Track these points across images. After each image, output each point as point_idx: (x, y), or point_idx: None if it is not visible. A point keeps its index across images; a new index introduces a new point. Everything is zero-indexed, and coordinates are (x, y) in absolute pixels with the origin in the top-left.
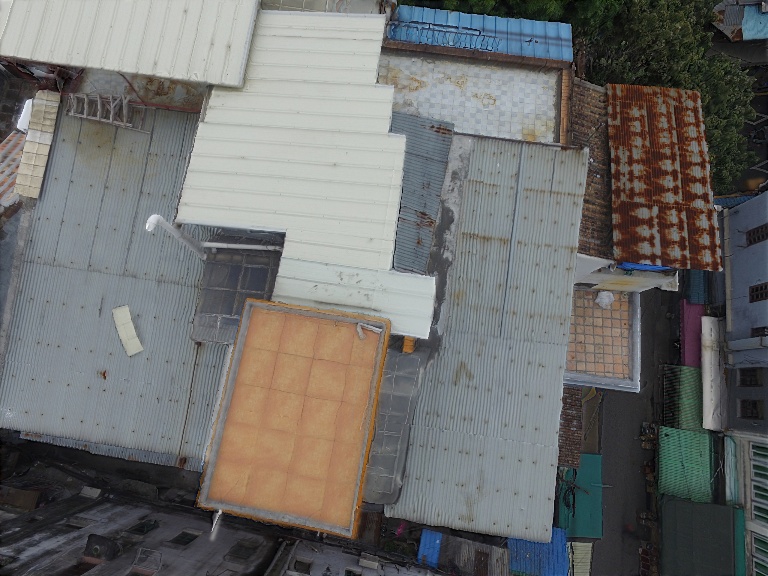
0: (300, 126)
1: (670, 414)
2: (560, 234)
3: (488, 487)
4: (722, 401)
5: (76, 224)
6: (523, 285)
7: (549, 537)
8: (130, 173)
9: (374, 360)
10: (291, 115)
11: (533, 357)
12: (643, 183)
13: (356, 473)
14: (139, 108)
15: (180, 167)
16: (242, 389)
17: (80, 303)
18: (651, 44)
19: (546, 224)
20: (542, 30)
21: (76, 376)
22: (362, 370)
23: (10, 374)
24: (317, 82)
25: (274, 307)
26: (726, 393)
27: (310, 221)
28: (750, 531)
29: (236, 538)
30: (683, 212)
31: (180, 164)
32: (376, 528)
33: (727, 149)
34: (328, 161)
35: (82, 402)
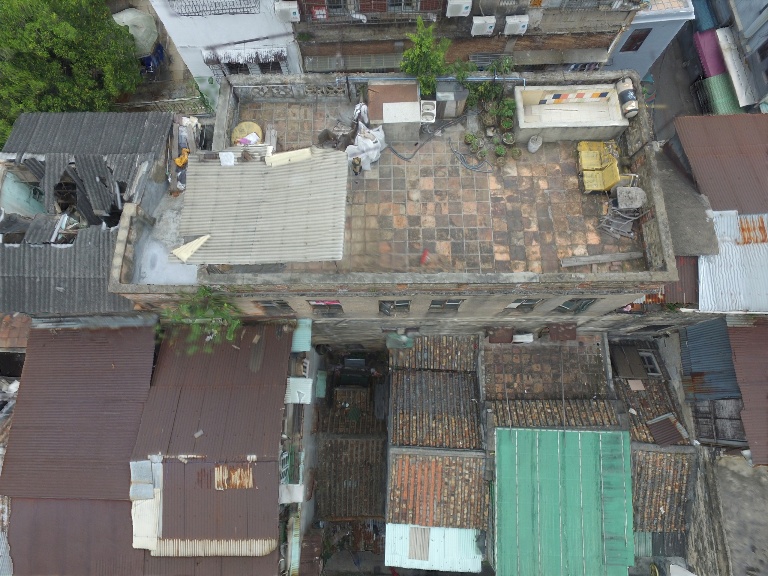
0: None
1: None
2: None
3: None
4: (750, 83)
5: None
6: None
7: None
8: None
9: None
10: None
11: None
12: None
13: None
14: None
15: None
16: None
17: None
18: None
19: None
20: None
21: None
22: None
23: None
24: None
25: None
26: (751, 75)
27: None
28: None
29: None
30: None
31: None
32: None
33: None
34: None
35: None
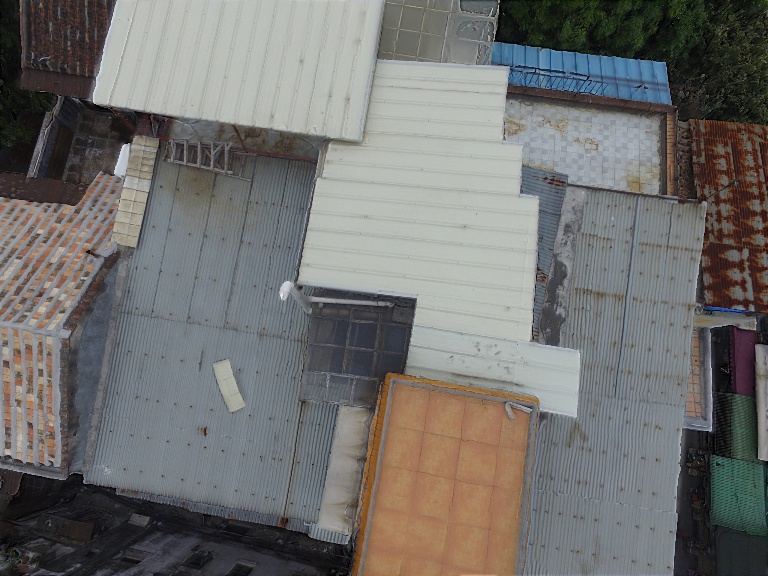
0: (425, 184)
1: (721, 443)
2: (677, 291)
3: (604, 554)
4: None
5: (174, 274)
6: (639, 343)
7: None
8: (230, 222)
9: (526, 442)
10: (414, 172)
11: (649, 418)
12: (731, 224)
13: (516, 566)
14: (239, 155)
15: (281, 216)
16: (389, 472)
17: (179, 356)
18: (732, 77)
19: (662, 280)
20: (636, 69)
21: (176, 432)
22: (513, 452)
23: (107, 429)
24: (440, 137)
25: (419, 384)
26: None
27: (442, 287)
28: None
29: (290, 570)
30: None
31: (281, 213)
32: None
33: None
34: (457, 222)
35: (182, 459)
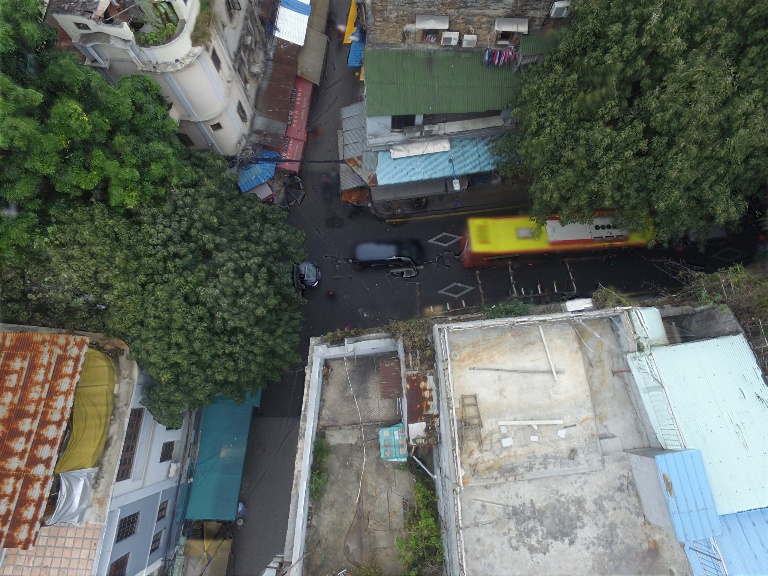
0: None
1: None
2: None
3: None
4: None
5: None
6: None
7: None
8: None
9: None
10: None
11: None
12: None
13: None
14: None
15: None
16: None
17: None
18: (69, 281)
19: None
20: None
21: None
22: None
23: None
24: None
25: None
26: None
27: None
28: None
29: None
30: (20, 480)
31: None
32: None
33: None
34: None
35: None
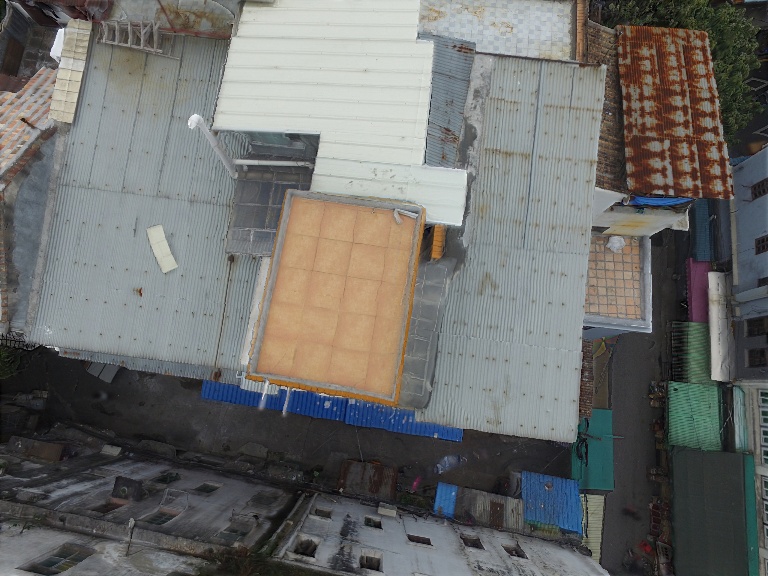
0: (330, 36)
1: (679, 369)
2: (580, 148)
3: (515, 391)
4: (730, 353)
5: (109, 148)
6: (545, 198)
7: (575, 437)
8: (161, 98)
9: (412, 242)
10: (321, 27)
11: (556, 267)
12: (654, 118)
13: (398, 343)
14: (168, 35)
15: (209, 91)
16: (286, 271)
17: (115, 224)
18: None
19: (566, 139)
20: None
21: (113, 293)
22: (400, 252)
23: (49, 293)
24: None
25: (314, 195)
26: (734, 345)
27: (343, 123)
28: (760, 475)
29: (256, 490)
30: (694, 145)
31: (209, 89)
32: (392, 483)
33: (733, 95)
34: (359, 68)
35: (119, 318)
